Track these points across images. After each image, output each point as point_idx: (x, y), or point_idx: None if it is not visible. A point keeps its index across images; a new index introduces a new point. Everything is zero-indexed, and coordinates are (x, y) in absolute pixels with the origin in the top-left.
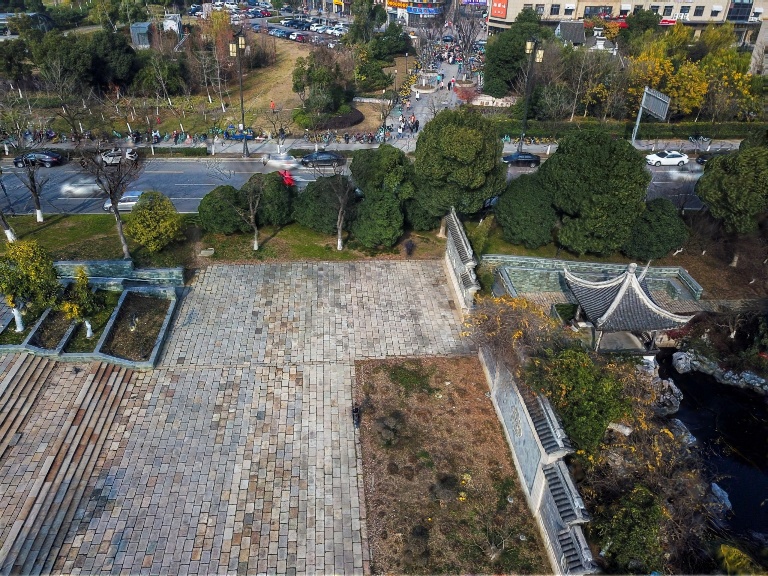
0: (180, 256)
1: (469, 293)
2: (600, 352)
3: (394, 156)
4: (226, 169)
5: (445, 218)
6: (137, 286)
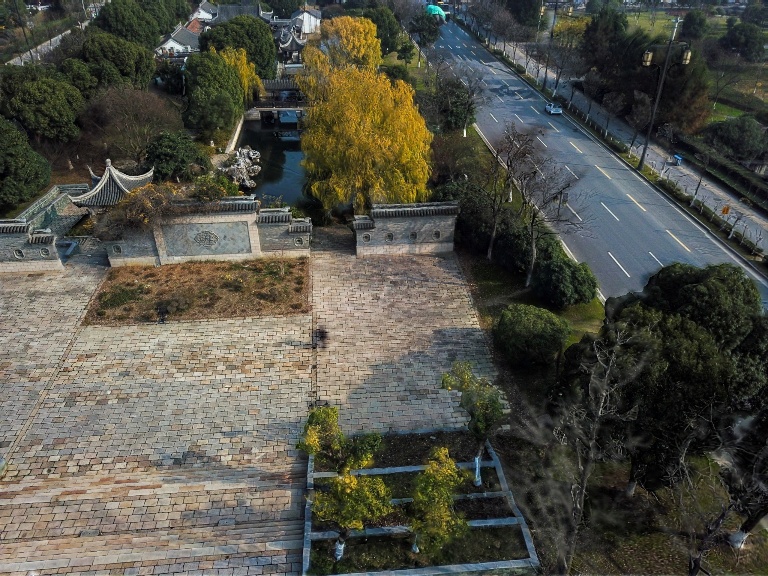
0: None
1: (53, 246)
2: None
3: None
4: None
5: None
6: None
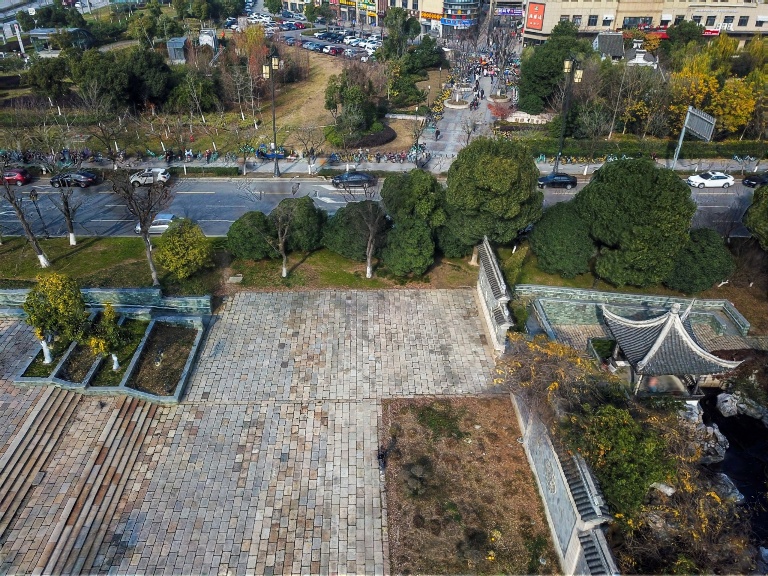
0: (208, 282)
1: (501, 329)
2: (640, 396)
3: (426, 183)
4: (257, 190)
5: (477, 248)
6: (165, 314)
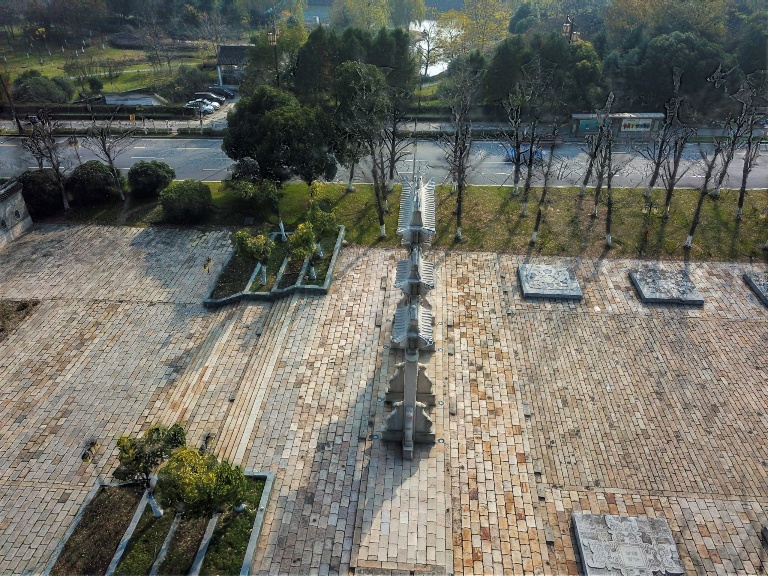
0: None
1: None
2: None
3: None
4: None
5: None
6: None
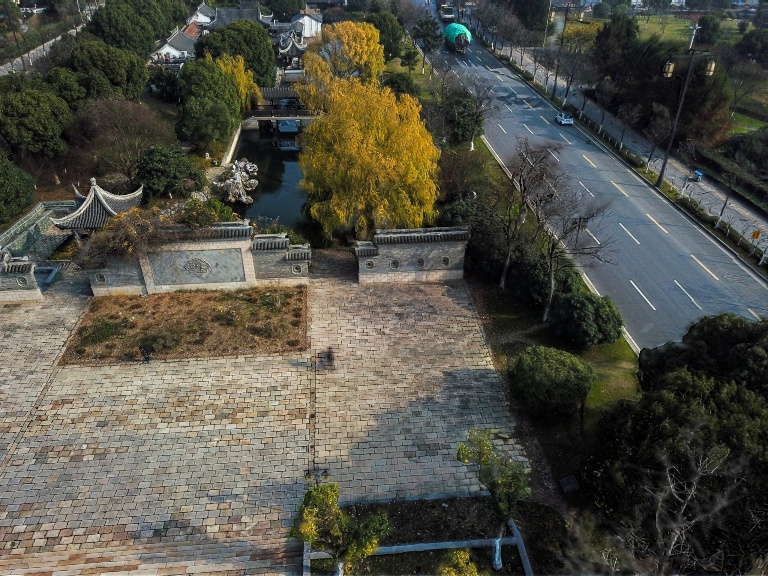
0: None
1: (31, 275)
2: None
3: None
4: None
5: None
6: None
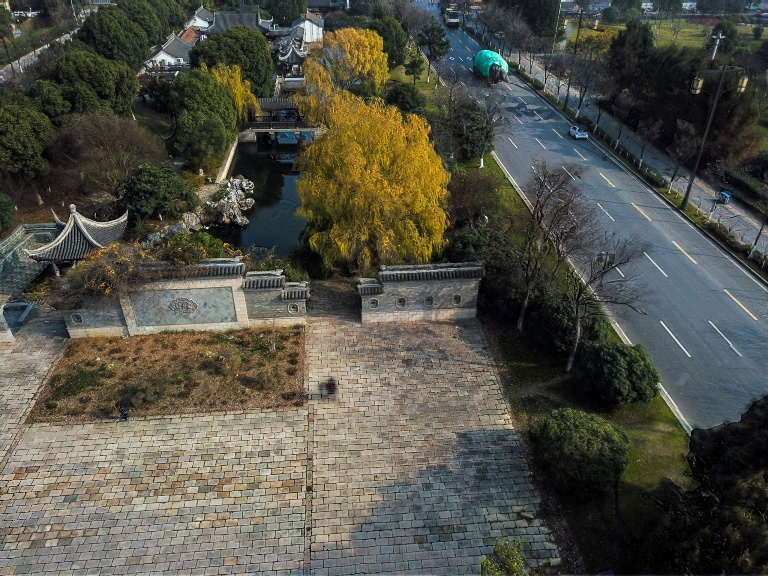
0: None
1: None
2: None
3: None
4: None
5: None
6: None
